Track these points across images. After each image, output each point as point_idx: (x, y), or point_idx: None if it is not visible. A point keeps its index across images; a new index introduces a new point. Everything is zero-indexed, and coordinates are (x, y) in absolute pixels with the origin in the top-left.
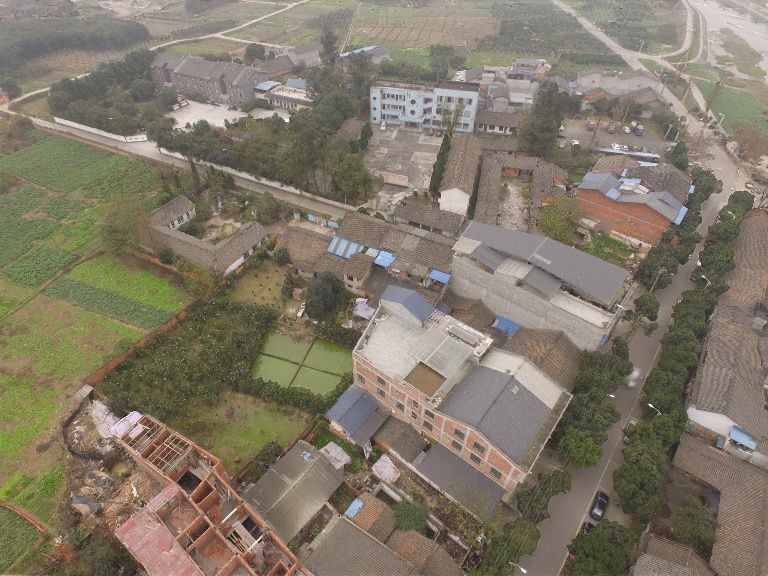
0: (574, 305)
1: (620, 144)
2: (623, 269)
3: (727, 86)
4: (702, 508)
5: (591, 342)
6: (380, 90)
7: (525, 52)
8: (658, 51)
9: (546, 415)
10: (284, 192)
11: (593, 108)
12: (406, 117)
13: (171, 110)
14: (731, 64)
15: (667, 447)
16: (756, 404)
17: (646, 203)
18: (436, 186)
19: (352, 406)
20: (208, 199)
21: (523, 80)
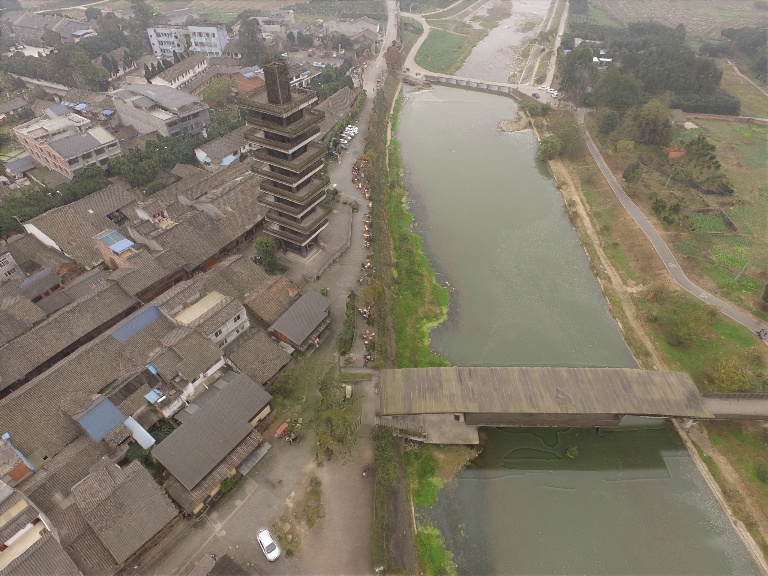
0: (161, 114)
1: (319, 62)
2: (198, 98)
3: (454, 33)
4: (168, 183)
5: (166, 132)
6: (153, 30)
7: (315, 13)
8: (427, 12)
9: (96, 145)
10: (59, 90)
11: (322, 43)
12: (173, 49)
13: (9, 51)
14: (479, 20)
15: (165, 163)
16: (226, 147)
17: (258, 76)
18: (148, 77)
19: (18, 160)
20: (5, 95)
21: (275, 25)
